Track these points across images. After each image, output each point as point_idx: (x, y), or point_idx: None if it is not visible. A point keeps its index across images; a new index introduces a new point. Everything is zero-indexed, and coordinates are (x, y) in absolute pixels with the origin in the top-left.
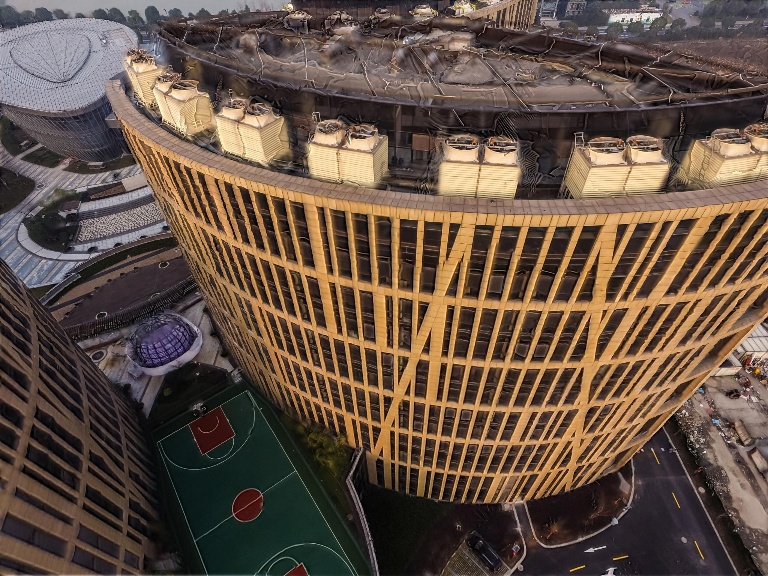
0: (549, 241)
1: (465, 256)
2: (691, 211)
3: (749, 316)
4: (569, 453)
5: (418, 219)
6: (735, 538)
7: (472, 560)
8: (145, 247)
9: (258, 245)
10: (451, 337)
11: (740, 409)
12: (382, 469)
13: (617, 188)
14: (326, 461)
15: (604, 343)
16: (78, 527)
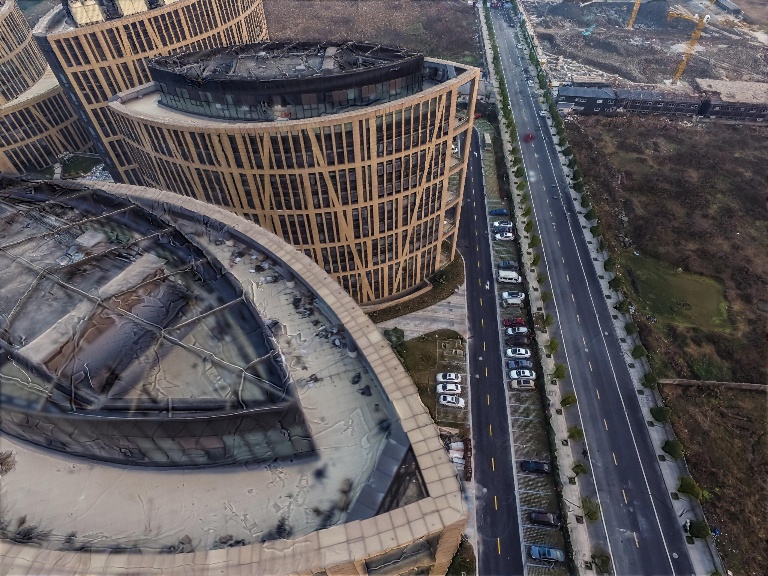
0: None
1: None
2: None
3: None
4: None
5: None
6: None
7: None
8: None
9: None
10: None
11: None
12: None
13: None
14: None
15: None
16: None
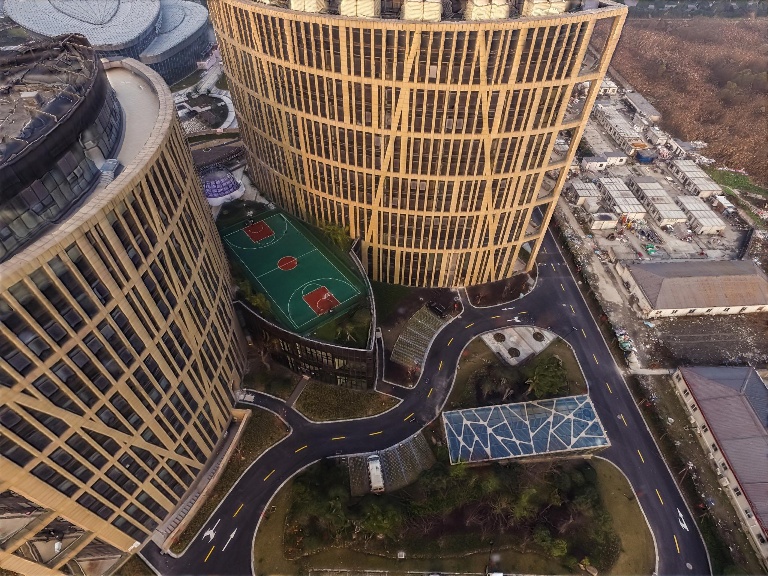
0: (455, 41)
1: (417, 52)
2: (516, 24)
3: (576, 119)
4: (487, 230)
5: (395, 29)
6: (595, 302)
7: (429, 314)
8: (191, 139)
9: (309, 64)
10: (412, 115)
11: (614, 245)
12: (371, 258)
13: (487, 17)
14: (337, 238)
15: (492, 119)
16: (209, 217)
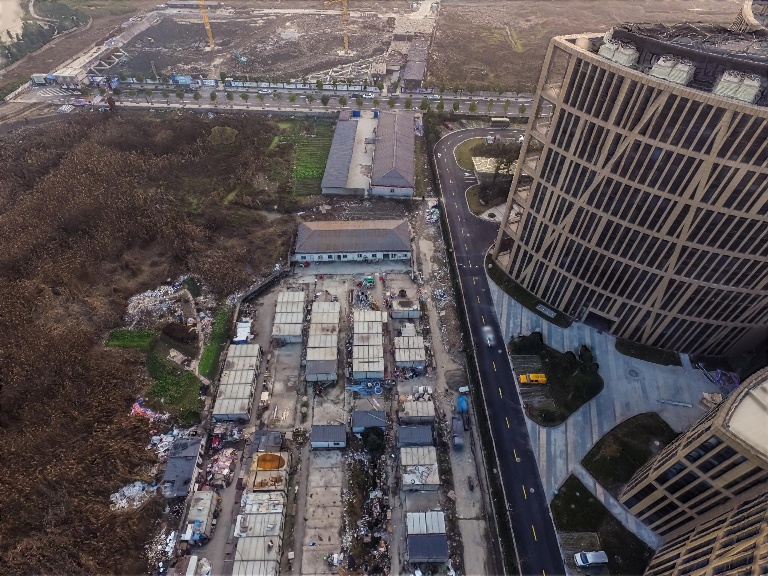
0: None
1: None
2: None
3: None
4: None
5: None
6: None
7: None
8: None
9: None
10: None
11: (402, 288)
12: None
13: None
14: None
15: None
16: None
